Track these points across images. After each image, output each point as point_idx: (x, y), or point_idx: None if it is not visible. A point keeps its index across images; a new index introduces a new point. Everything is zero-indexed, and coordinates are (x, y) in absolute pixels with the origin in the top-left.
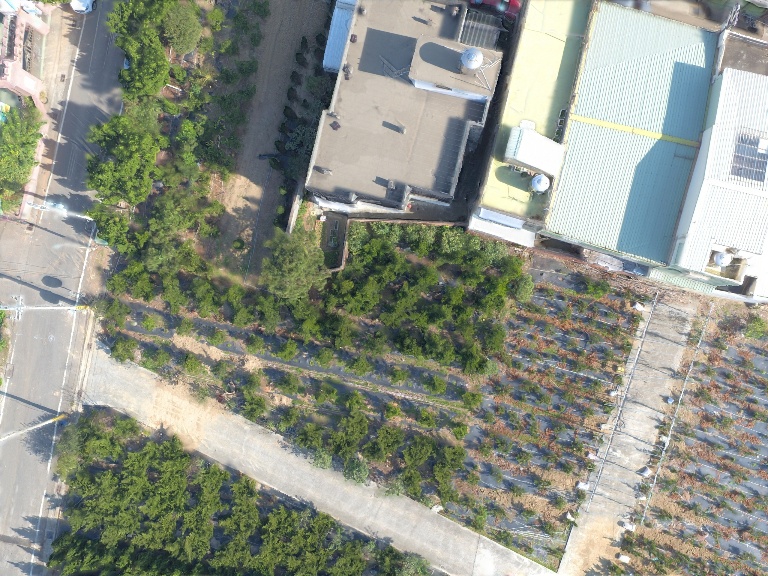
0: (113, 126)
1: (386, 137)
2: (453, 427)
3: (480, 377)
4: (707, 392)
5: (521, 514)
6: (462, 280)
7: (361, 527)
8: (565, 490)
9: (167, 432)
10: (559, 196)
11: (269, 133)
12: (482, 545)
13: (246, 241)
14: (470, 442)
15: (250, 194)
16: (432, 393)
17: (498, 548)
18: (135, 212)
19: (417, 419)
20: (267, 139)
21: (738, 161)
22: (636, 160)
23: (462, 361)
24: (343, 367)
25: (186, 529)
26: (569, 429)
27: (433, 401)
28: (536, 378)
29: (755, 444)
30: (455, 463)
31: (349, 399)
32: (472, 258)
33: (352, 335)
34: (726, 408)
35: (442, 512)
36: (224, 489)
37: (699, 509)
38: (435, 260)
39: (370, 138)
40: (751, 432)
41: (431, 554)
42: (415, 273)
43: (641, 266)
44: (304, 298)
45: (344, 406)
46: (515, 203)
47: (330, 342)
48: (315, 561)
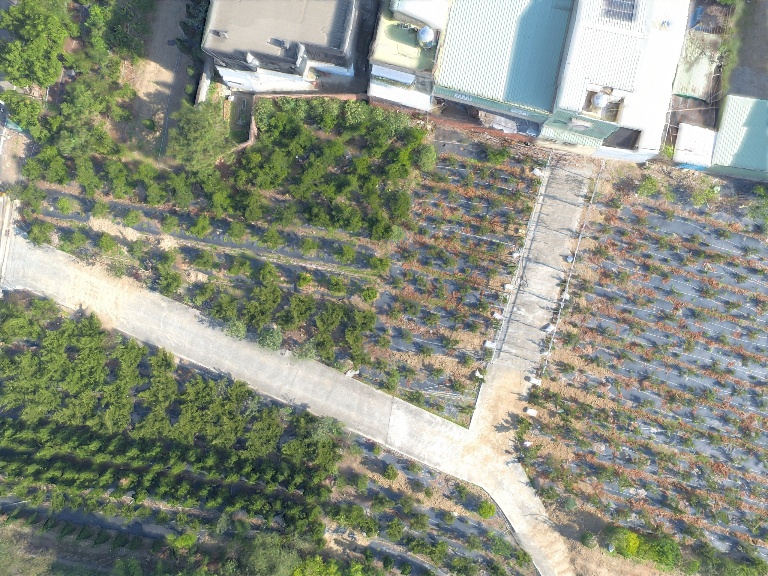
0: (19, 8)
1: (279, 0)
2: None
3: (388, 245)
4: (604, 249)
5: (432, 374)
6: (367, 152)
7: (278, 395)
8: (473, 349)
9: (86, 312)
10: (446, 51)
11: (177, 20)
12: (396, 406)
13: (157, 124)
14: (381, 308)
15: (160, 79)
16: (343, 262)
17: (411, 408)
18: (48, 100)
19: (329, 288)
20: (175, 25)
21: (607, 4)
22: (516, 13)
23: (369, 228)
24: (256, 242)
25: (106, 402)
26: (475, 291)
27: (344, 270)
28: (442, 244)
29: (652, 298)
30: (366, 326)
31: (261, 269)
32: (374, 127)
33: (262, 207)
34: (623, 264)
35: (356, 377)
36: (144, 365)
37: (600, 360)
38: (341, 135)
39: (263, 2)
40: (647, 286)
41: (347, 417)
42: (320, 144)
43: (531, 123)
44: (215, 175)
45: (258, 279)
46: (404, 59)
47: (243, 218)
48: (233, 427)
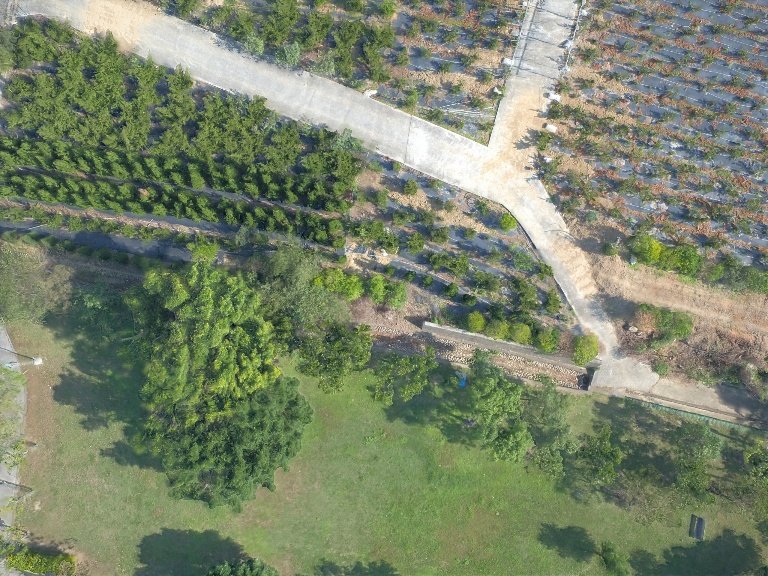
0: None
1: None
2: (381, 14)
3: None
4: None
5: (450, 92)
6: None
7: (296, 115)
8: (491, 67)
9: (101, 36)
10: None
11: None
12: (414, 125)
13: None
14: (398, 29)
15: None
16: None
17: (430, 126)
18: None
19: (345, 9)
20: None
21: None
22: None
23: None
24: None
25: (122, 119)
26: (492, 8)
27: None
28: None
29: (669, 15)
30: None
31: None
32: None
33: None
34: None
35: (374, 96)
36: (160, 90)
37: (619, 75)
38: None
39: None
40: (665, 3)
41: (365, 136)
42: None
43: None
44: None
45: (274, 1)
46: None
47: None
48: (251, 142)
